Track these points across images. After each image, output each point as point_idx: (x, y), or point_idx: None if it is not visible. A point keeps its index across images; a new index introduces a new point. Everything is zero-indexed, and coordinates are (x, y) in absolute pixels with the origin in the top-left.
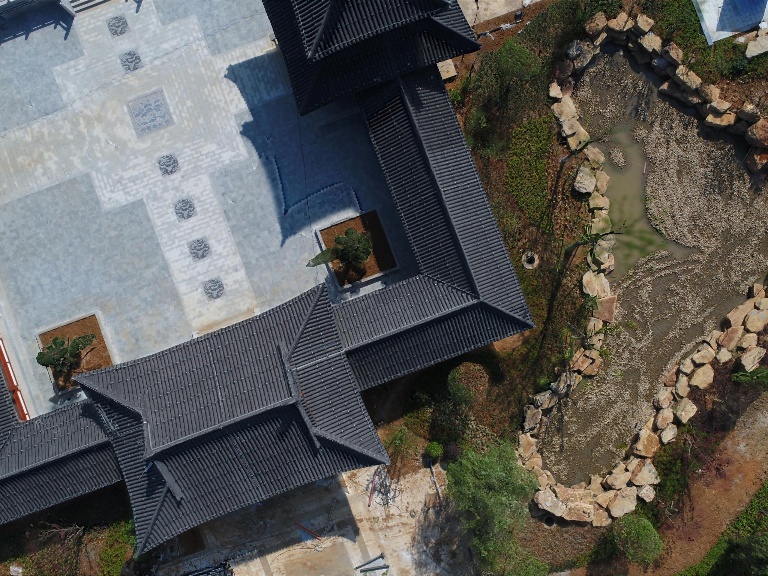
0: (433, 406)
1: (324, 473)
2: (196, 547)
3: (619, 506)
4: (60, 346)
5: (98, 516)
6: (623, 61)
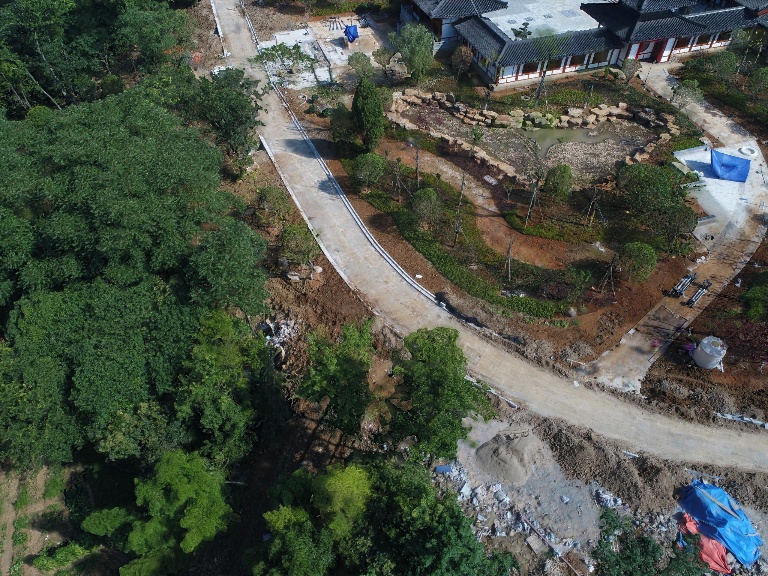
0: (445, 69)
1: (424, 8)
2: (377, 21)
3: (393, 116)
4: None
5: (393, 2)
6: (651, 137)
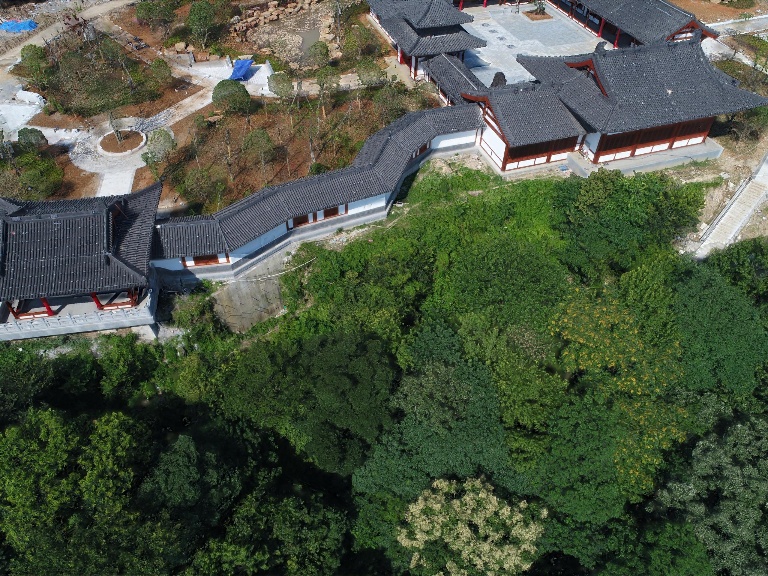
0: None
1: None
2: None
3: None
4: (540, 2)
5: None
6: None
